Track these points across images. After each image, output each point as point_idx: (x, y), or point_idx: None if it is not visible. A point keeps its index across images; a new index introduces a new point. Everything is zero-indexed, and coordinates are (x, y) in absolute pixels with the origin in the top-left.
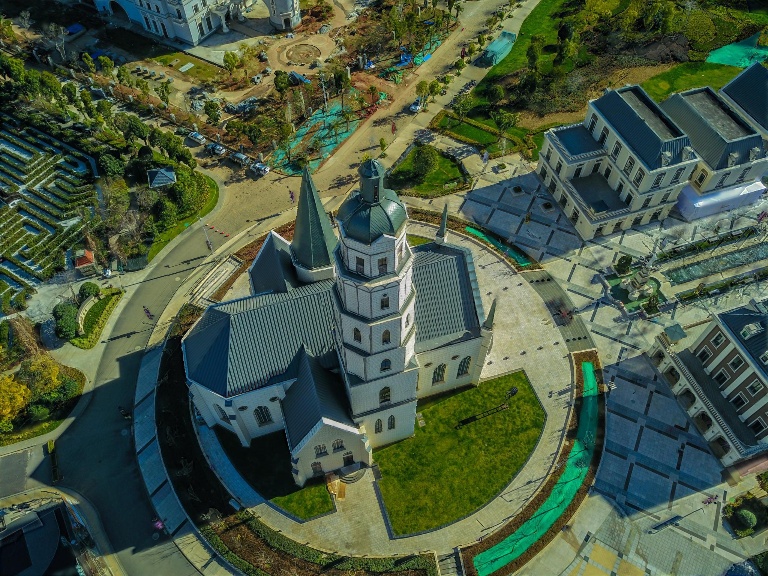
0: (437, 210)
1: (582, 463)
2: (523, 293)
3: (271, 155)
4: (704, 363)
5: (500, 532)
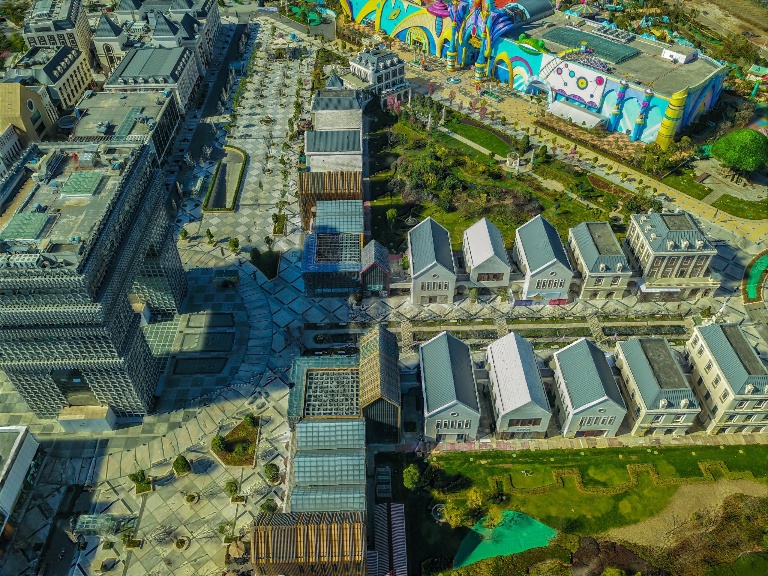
0: None
1: (760, 263)
2: None
3: None
4: None
5: None
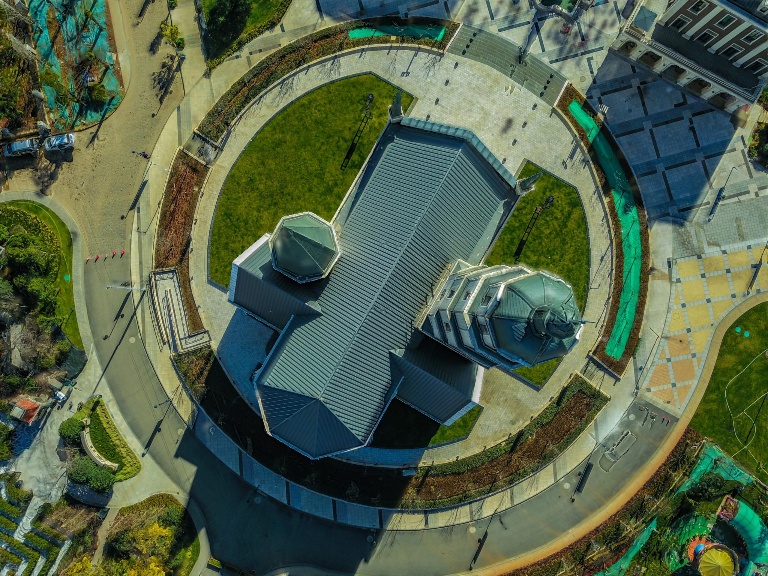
0: (298, 34)
1: (629, 206)
2: (466, 73)
3: (48, 110)
4: (681, 30)
5: (610, 317)
